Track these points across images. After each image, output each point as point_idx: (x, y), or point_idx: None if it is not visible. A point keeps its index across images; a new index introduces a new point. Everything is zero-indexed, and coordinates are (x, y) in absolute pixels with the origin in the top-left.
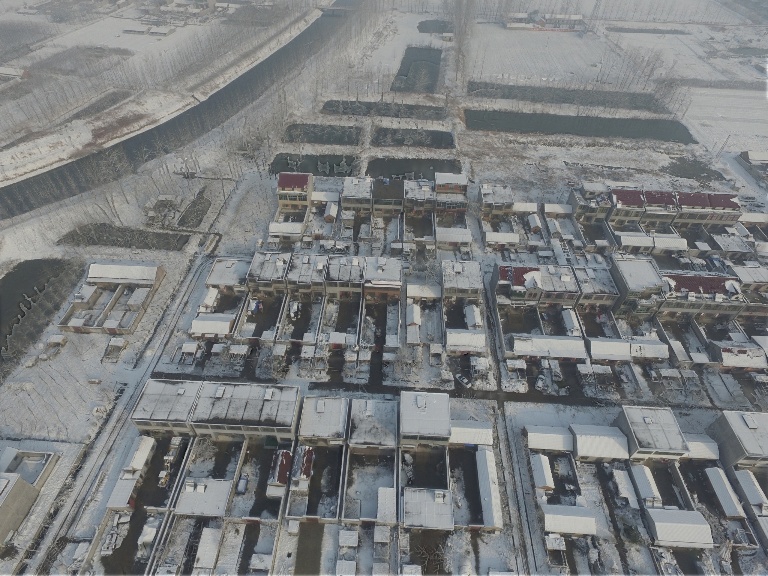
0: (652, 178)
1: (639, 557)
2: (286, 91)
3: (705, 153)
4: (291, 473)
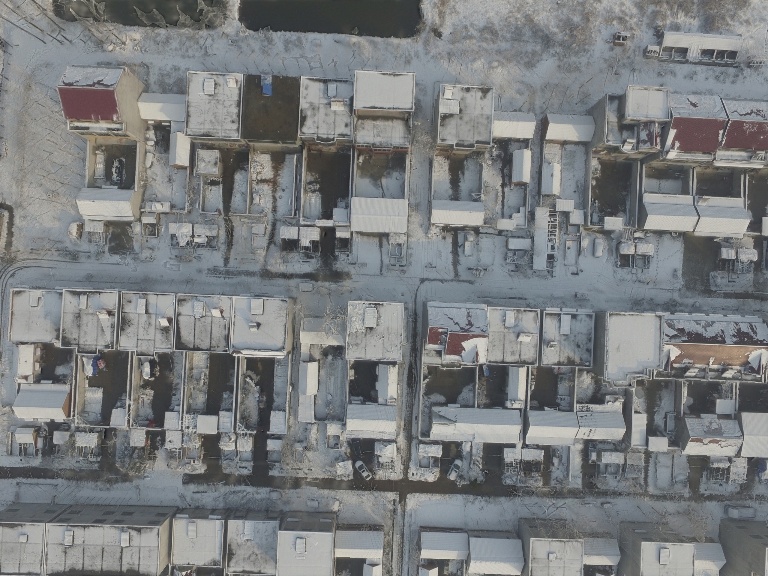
0: None
1: None
2: None
3: None
4: None
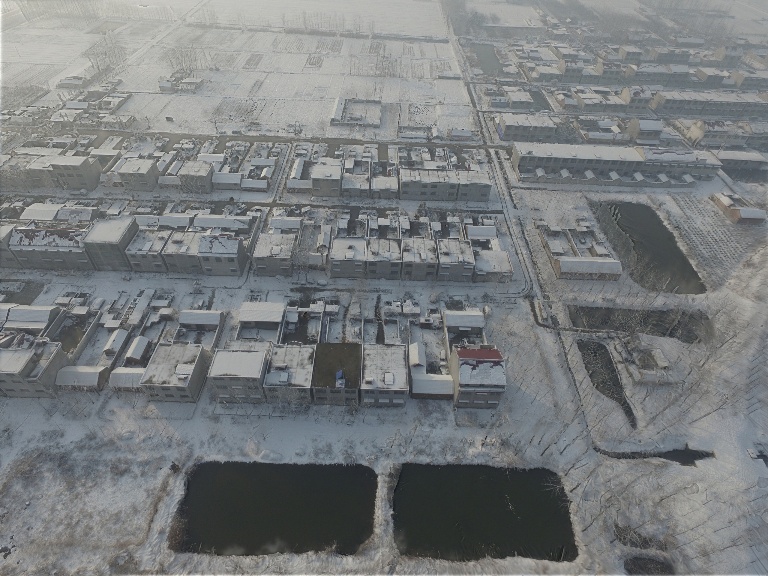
0: None
1: None
2: None
3: None
4: (397, 171)
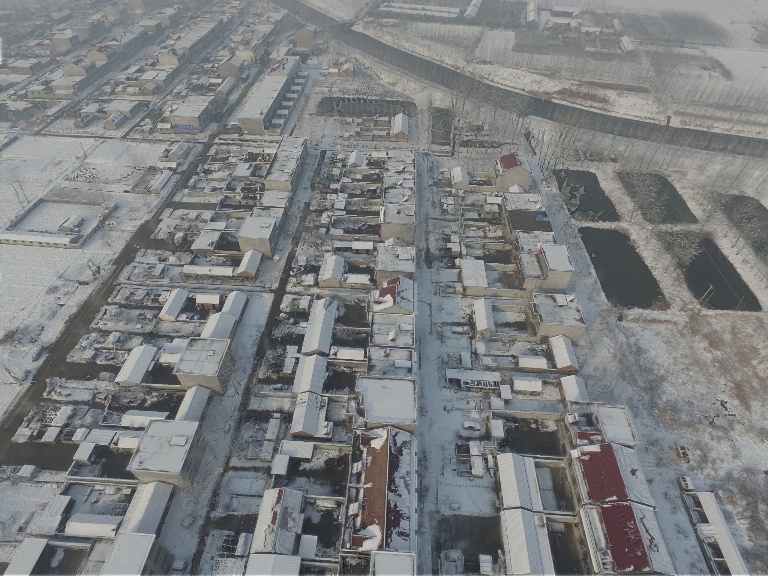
0: None
1: (137, 343)
2: (730, 160)
3: None
4: None
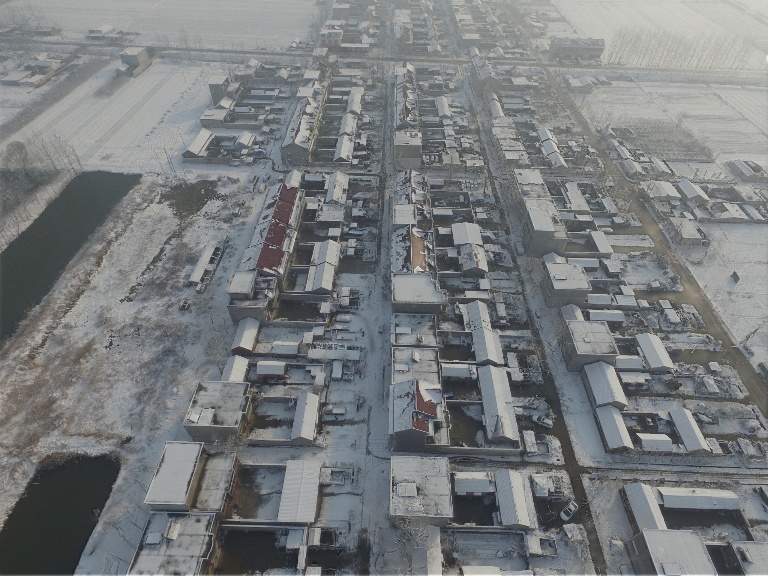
0: (196, 230)
1: (684, 386)
2: None
3: (163, 177)
4: None
